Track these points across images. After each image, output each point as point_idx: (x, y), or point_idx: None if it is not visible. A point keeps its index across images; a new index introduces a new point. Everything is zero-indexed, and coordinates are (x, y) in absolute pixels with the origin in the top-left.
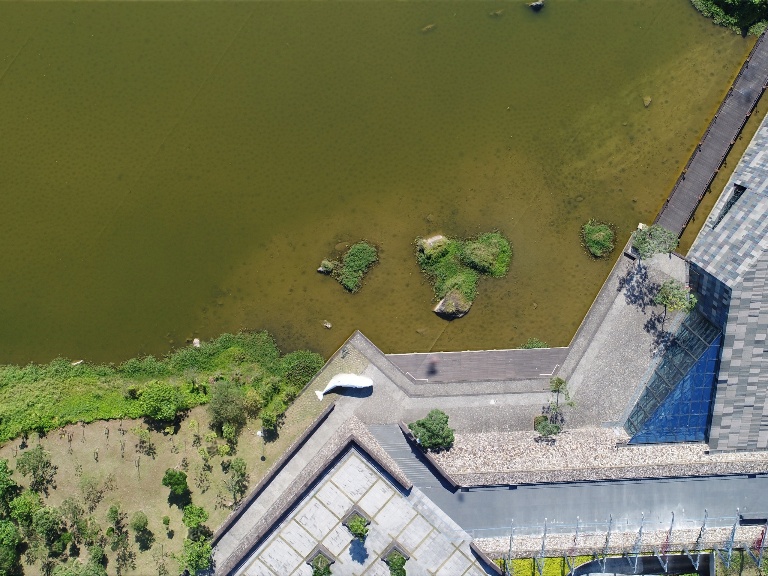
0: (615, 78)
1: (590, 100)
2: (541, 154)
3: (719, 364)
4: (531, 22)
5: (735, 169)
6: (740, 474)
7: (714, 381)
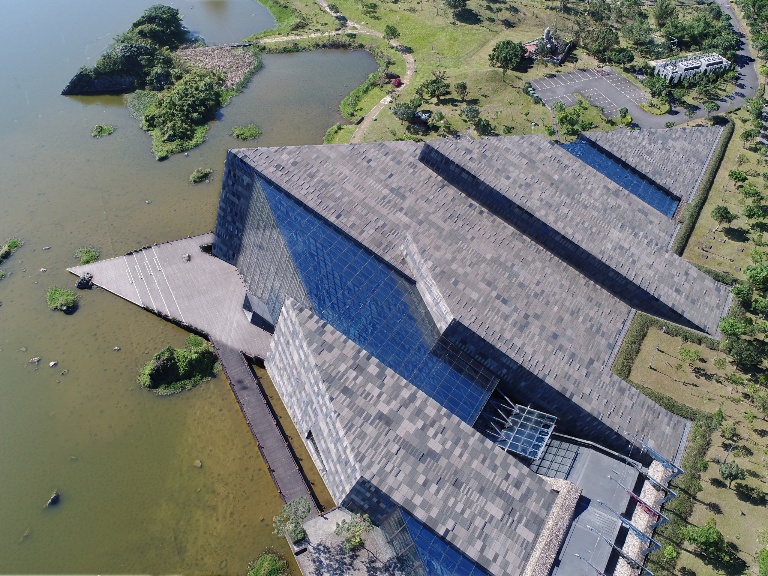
0: (161, 476)
1: (158, 505)
2: (160, 574)
3: (427, 527)
4: (60, 513)
5: (299, 433)
6: (549, 572)
7: (444, 541)
